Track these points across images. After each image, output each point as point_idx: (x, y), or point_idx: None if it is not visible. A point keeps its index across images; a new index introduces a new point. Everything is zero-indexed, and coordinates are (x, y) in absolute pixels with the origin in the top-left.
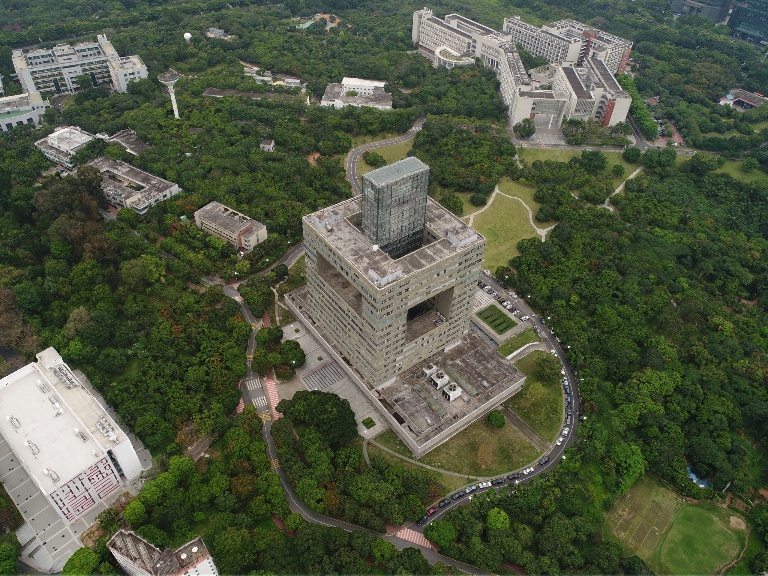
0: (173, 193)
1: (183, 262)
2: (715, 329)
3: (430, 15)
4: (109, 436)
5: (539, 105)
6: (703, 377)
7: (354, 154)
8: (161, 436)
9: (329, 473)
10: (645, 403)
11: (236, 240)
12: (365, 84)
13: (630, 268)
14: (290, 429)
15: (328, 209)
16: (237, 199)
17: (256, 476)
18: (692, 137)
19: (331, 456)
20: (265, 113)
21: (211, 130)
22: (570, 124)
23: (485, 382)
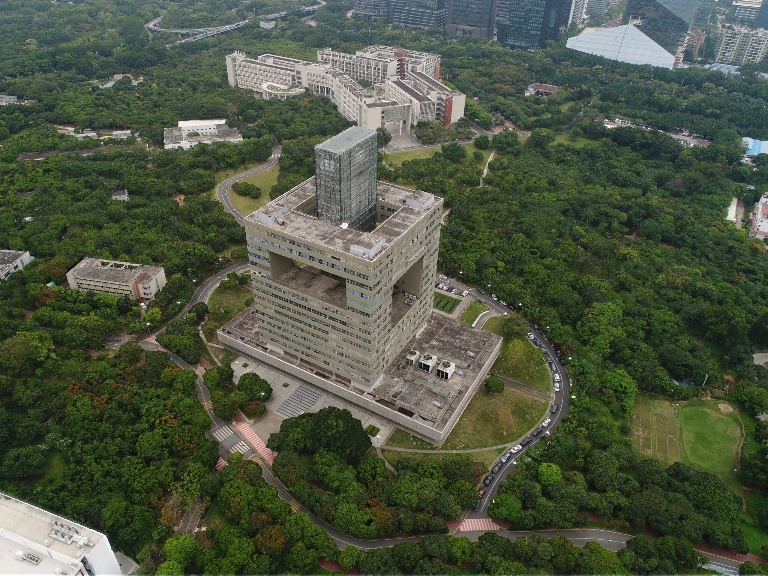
0: (25, 263)
1: (75, 328)
2: (624, 259)
3: (243, 57)
4: (75, 541)
5: (387, 113)
6: (638, 298)
7: (221, 189)
8: (140, 523)
9: (363, 490)
10: (609, 331)
11: (131, 291)
12: (205, 124)
13: (533, 228)
14: (297, 460)
15: (270, 204)
16: (111, 252)
17: (281, 525)
18: (522, 121)
19: (354, 474)
20: (105, 165)
21: (47, 190)
22: (420, 126)
23: (470, 352)
